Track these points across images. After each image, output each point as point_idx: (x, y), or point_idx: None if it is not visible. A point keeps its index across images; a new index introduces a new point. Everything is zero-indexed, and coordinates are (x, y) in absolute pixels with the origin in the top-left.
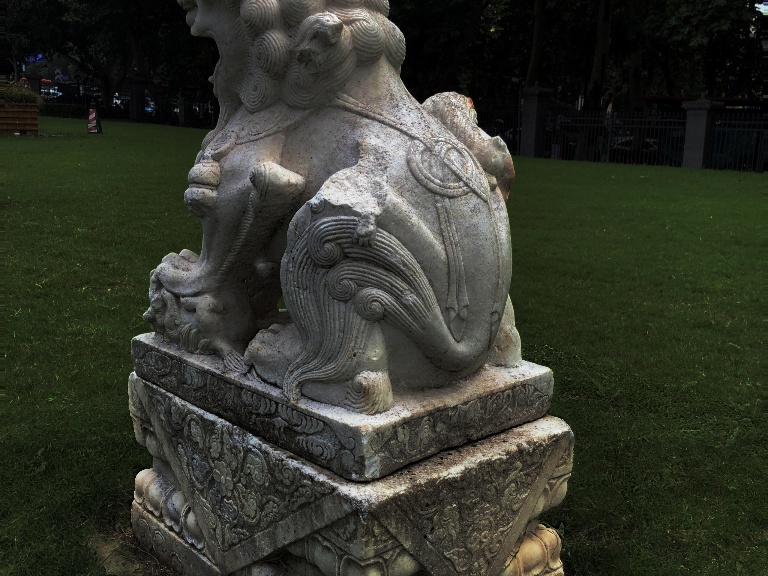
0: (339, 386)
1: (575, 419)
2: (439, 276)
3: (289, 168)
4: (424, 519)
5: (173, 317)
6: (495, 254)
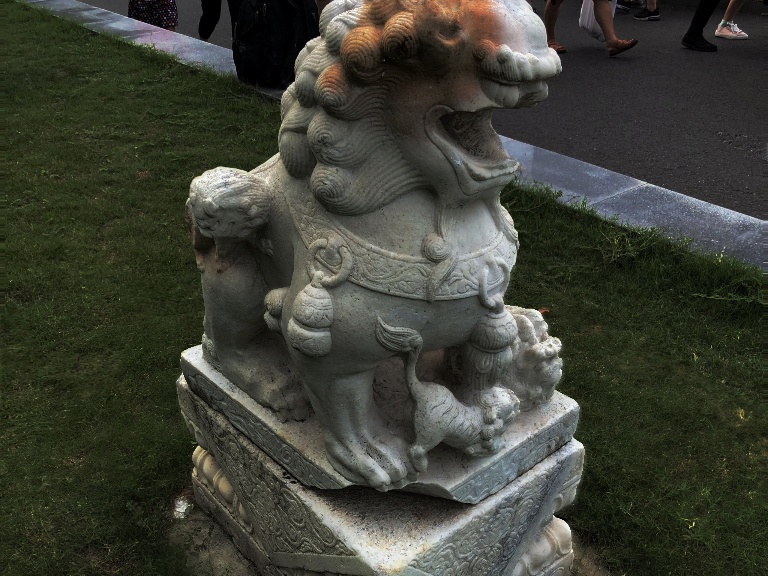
0: None
1: None
2: None
3: None
4: None
5: None
6: None
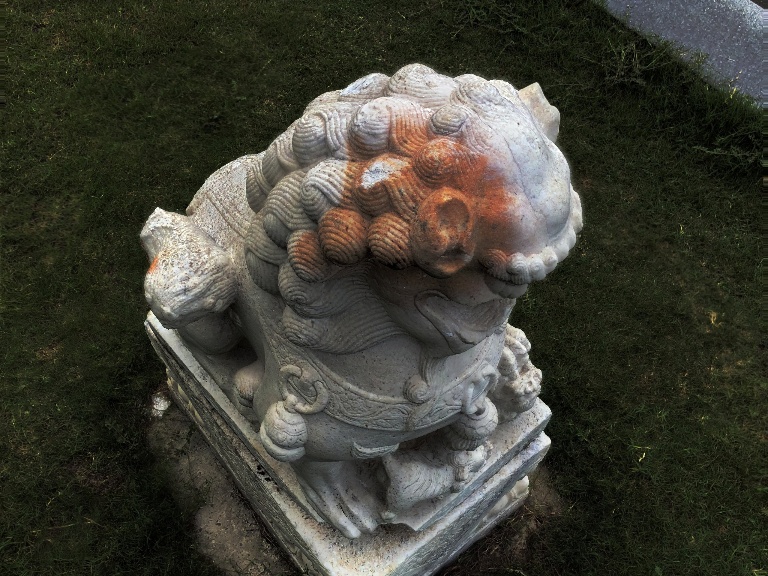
0: None
1: None
2: None
3: None
4: None
5: None
6: None
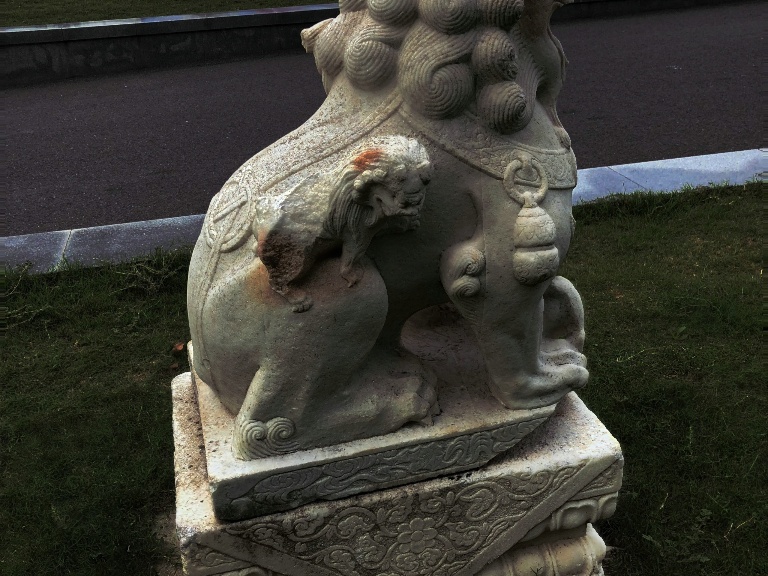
0: None
1: None
2: None
3: None
4: None
5: None
6: None
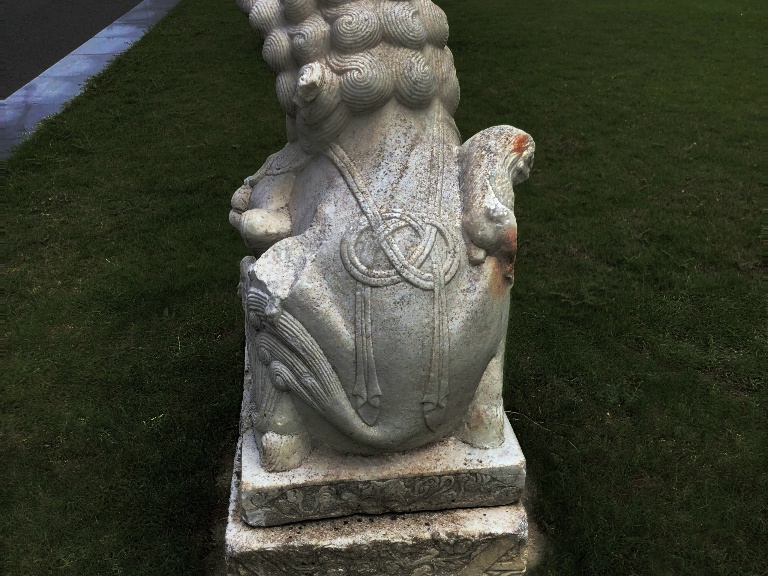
0: (260, 434)
1: (761, 464)
2: (344, 365)
3: (290, 210)
4: (301, 573)
5: (243, 305)
6: (427, 347)
